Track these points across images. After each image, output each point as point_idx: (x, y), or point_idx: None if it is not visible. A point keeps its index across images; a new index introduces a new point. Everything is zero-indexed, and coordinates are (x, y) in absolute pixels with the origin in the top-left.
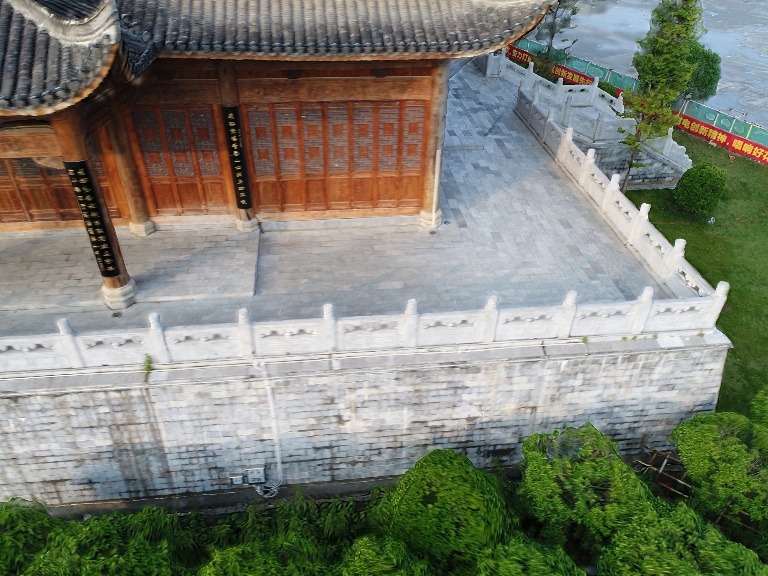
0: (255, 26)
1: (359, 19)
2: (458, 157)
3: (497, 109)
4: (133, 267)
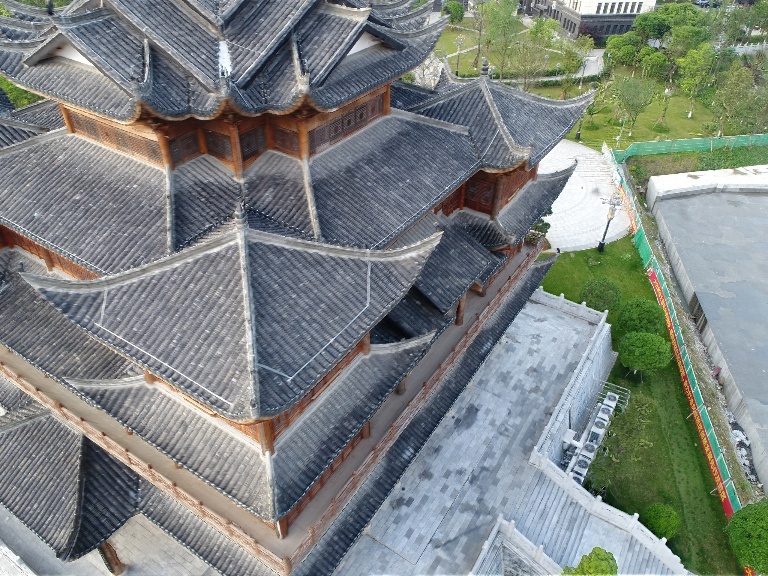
0: (183, 519)
1: (229, 544)
2: (388, 563)
3: (484, 516)
4: (140, 555)
